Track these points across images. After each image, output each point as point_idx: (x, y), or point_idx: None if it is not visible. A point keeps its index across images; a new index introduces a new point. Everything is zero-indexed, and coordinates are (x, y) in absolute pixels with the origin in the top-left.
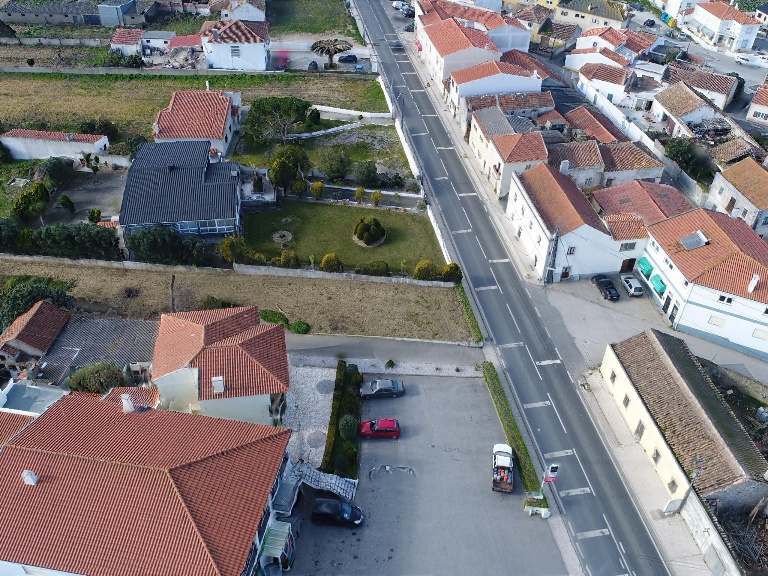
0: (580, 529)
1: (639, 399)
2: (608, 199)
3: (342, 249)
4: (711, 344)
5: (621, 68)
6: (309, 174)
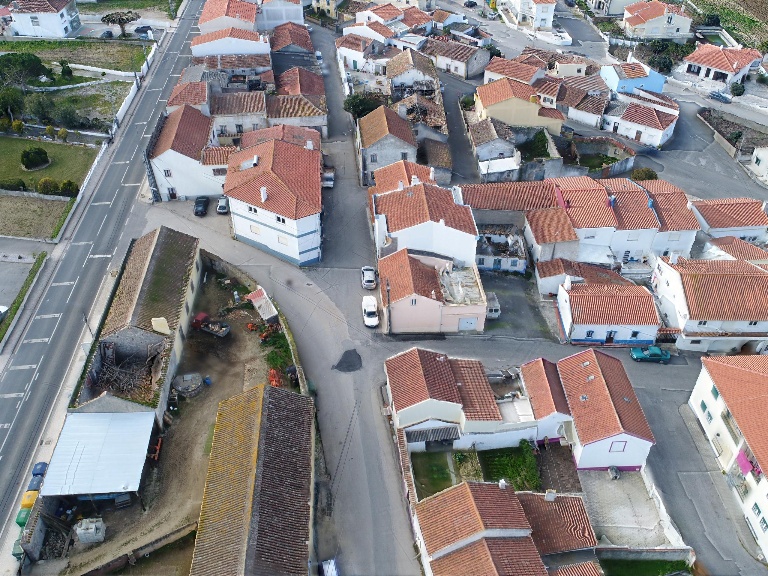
0: (16, 364)
1: (116, 275)
2: (250, 139)
3: (5, 171)
4: (257, 251)
5: (365, 37)
6: (28, 117)
